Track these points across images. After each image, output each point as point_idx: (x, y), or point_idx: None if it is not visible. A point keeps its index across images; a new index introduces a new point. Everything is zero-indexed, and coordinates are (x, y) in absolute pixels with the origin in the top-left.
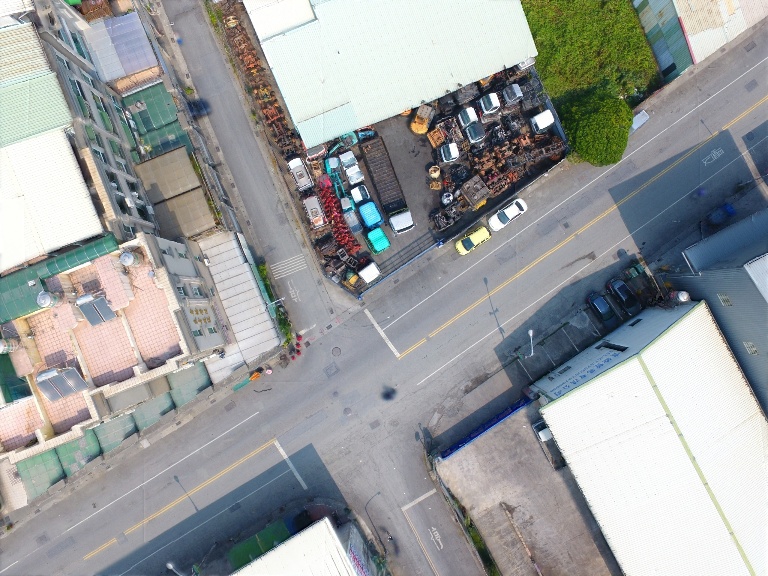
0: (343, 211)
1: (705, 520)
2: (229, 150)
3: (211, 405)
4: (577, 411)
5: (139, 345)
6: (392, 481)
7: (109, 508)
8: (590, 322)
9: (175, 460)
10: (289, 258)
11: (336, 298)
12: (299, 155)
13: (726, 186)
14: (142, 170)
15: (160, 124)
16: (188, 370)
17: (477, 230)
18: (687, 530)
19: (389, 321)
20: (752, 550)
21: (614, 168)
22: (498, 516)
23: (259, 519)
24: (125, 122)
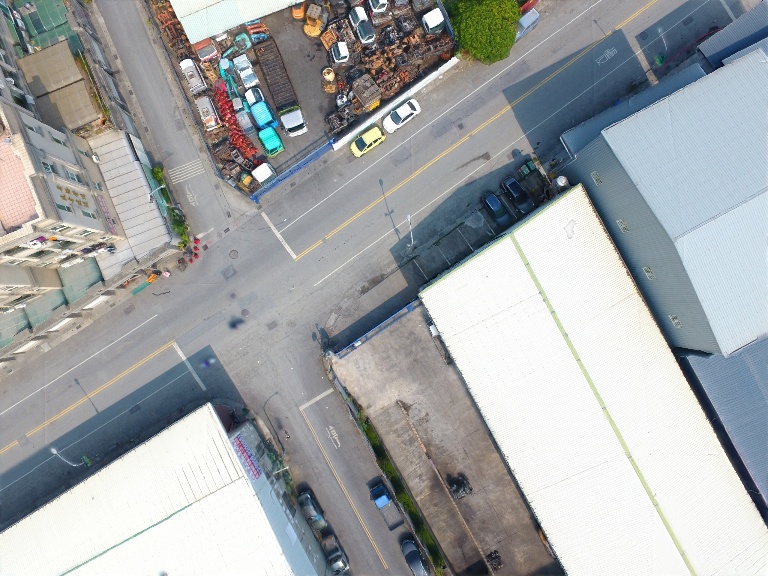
0: (235, 112)
1: (578, 396)
2: (127, 57)
3: (111, 309)
4: (454, 293)
5: (0, 214)
6: (290, 381)
7: (11, 411)
8: (485, 222)
9: (75, 363)
10: (187, 163)
11: (233, 202)
12: (193, 59)
13: (620, 86)
14: (24, 63)
15: (51, 26)
16: (79, 267)
17: (369, 130)
18: (562, 407)
19: (286, 223)
20: (625, 425)
21: (508, 69)
22: (395, 414)
23: (159, 420)
24: (11, 20)
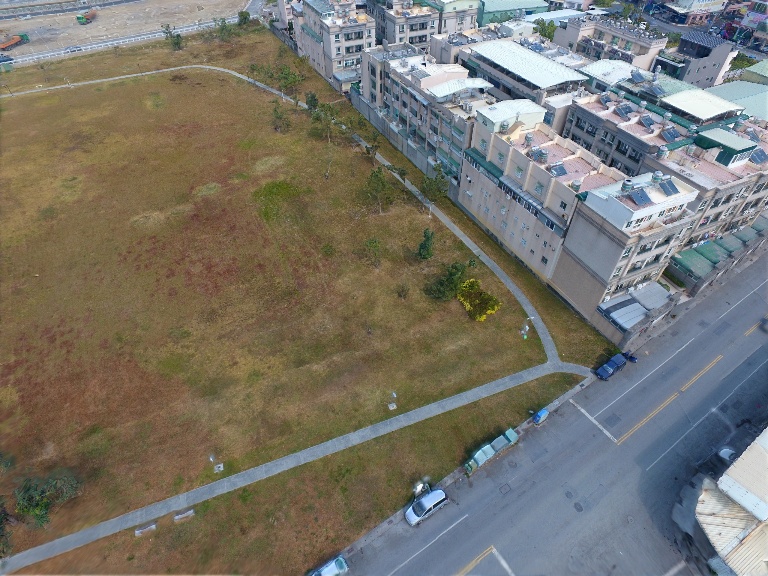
0: None
1: None
2: None
3: (765, 251)
4: None
5: None
6: None
7: (740, 304)
8: None
9: (766, 277)
10: None
11: None
12: None
13: None
14: None
15: None
16: None
17: None
18: None
19: None
20: None
21: None
22: None
23: None
24: None
